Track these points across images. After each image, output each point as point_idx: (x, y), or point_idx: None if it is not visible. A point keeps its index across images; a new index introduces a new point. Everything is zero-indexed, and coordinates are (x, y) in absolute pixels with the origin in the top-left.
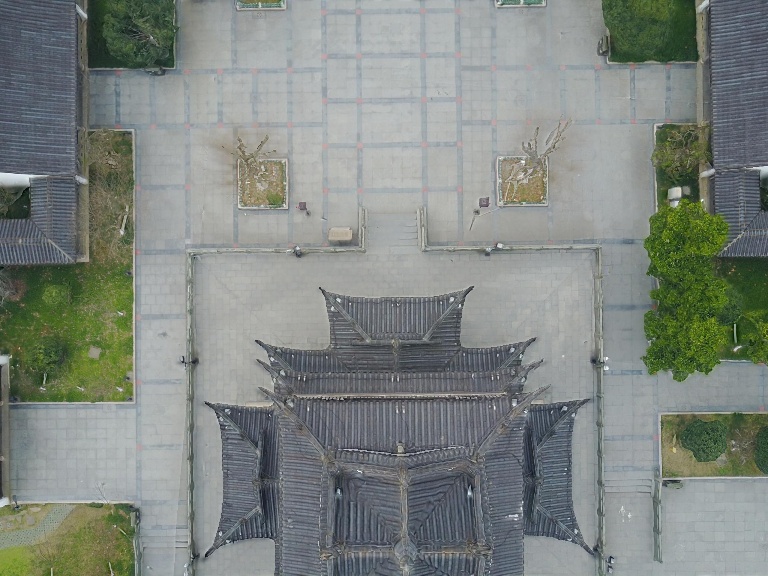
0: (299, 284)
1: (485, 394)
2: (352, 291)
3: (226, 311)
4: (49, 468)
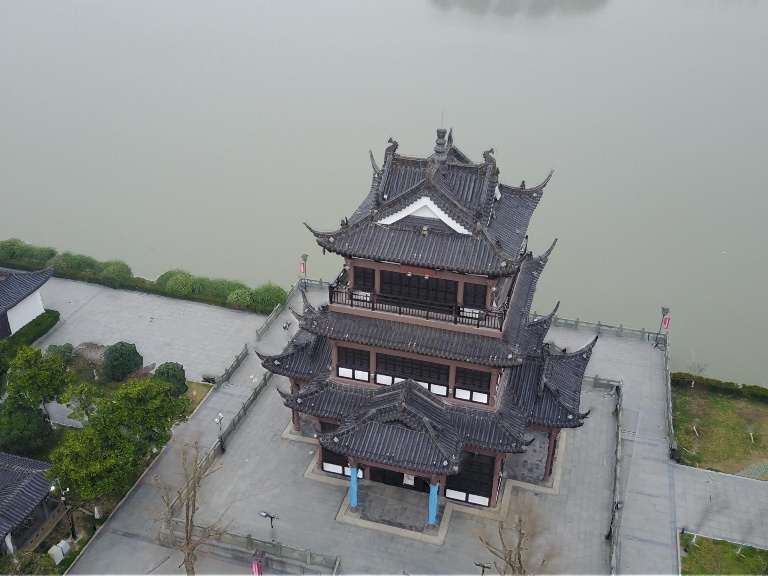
0: (485, 575)
1: (345, 306)
2: (428, 555)
3: (572, 572)
4: (767, 504)
